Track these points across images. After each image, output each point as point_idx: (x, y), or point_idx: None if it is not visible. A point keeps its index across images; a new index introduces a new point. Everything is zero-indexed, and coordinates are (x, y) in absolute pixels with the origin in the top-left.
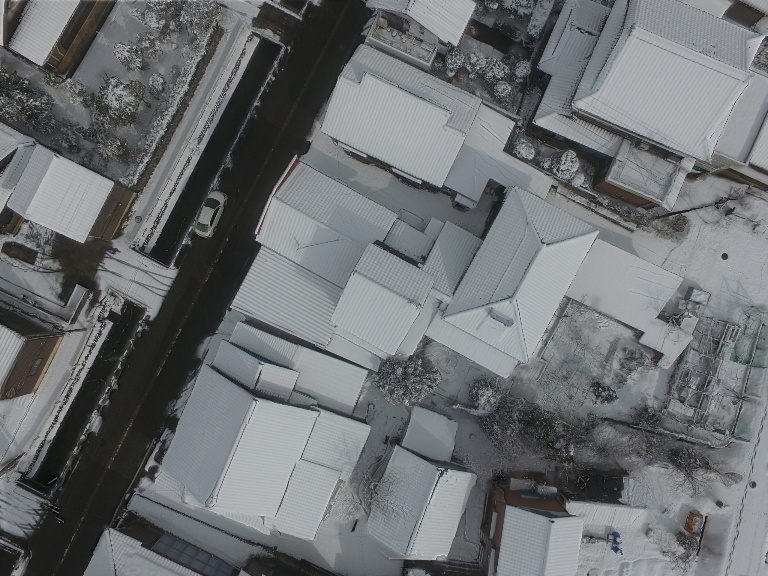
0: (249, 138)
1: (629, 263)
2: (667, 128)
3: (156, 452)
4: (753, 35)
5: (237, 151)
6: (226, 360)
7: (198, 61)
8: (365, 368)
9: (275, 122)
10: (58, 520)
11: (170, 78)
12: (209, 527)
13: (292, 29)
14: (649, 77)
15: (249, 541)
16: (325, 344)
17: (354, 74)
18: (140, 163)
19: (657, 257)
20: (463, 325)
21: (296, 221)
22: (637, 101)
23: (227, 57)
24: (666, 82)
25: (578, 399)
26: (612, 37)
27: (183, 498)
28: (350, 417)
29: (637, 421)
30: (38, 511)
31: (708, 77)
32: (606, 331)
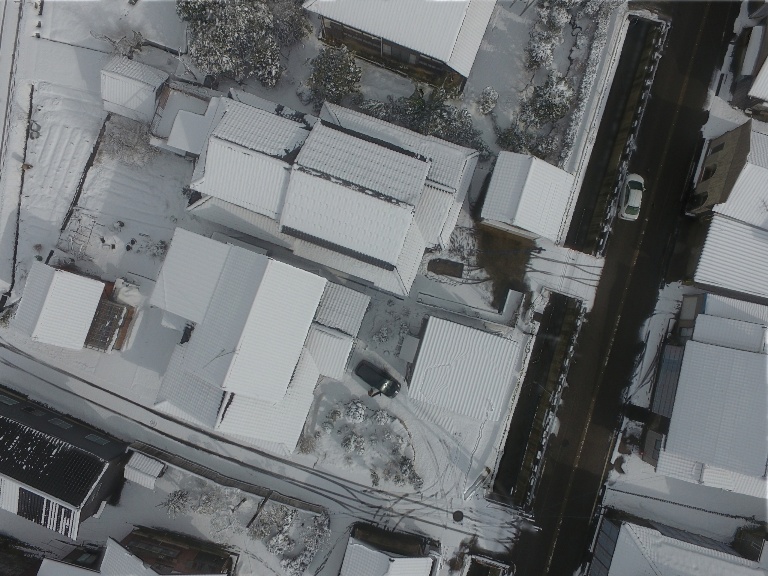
0: (648, 118)
1: None
2: None
3: (620, 442)
4: None
5: (639, 132)
6: (713, 332)
7: None
8: None
9: (670, 98)
10: (535, 528)
11: (563, 72)
12: (687, 508)
13: (668, 6)
14: None
15: (728, 515)
16: None
17: None
18: (566, 157)
19: None
20: None
21: (767, 182)
22: None
23: (610, 43)
24: None
25: None
26: None
27: (701, 477)
28: None
29: None
30: (513, 523)
31: None
32: None
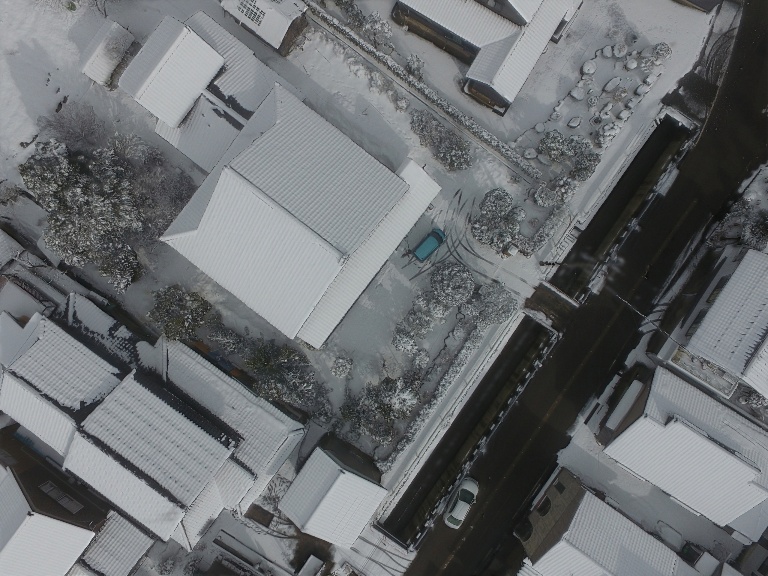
0: (507, 424)
1: None
2: None
3: None
4: None
5: (493, 436)
6: None
7: None
8: None
9: (537, 411)
10: None
11: (434, 354)
12: None
13: (566, 315)
14: None
15: None
16: None
17: (658, 412)
18: (401, 451)
19: None
20: None
21: (580, 562)
22: None
23: (494, 336)
24: None
25: None
26: None
27: None
28: None
29: None
30: None
31: None
32: None
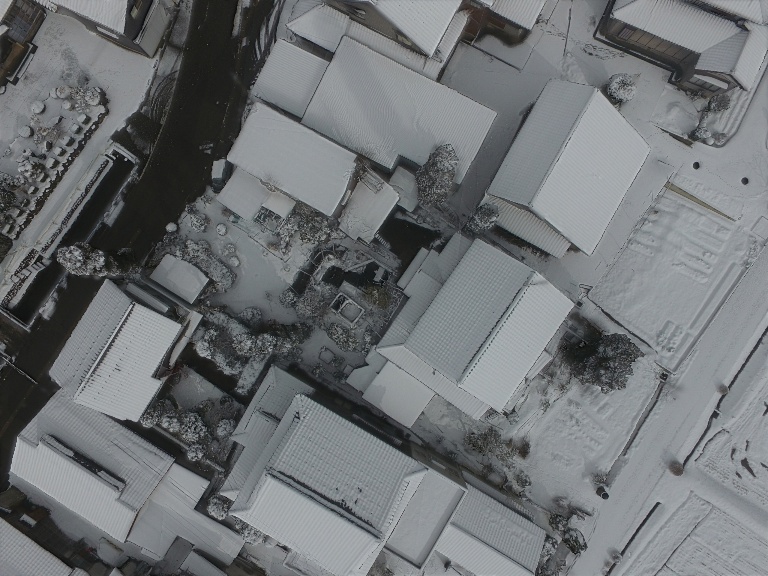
0: None
1: None
2: (317, 553)
3: None
4: (416, 468)
5: None
6: None
7: None
8: None
9: None
10: None
11: None
12: None
13: (19, 339)
14: (292, 512)
15: None
16: None
17: (36, 432)
18: None
19: None
20: None
21: None
22: (286, 526)
23: None
24: (308, 520)
25: None
26: None
27: None
28: None
29: None
30: None
31: (344, 528)
32: None
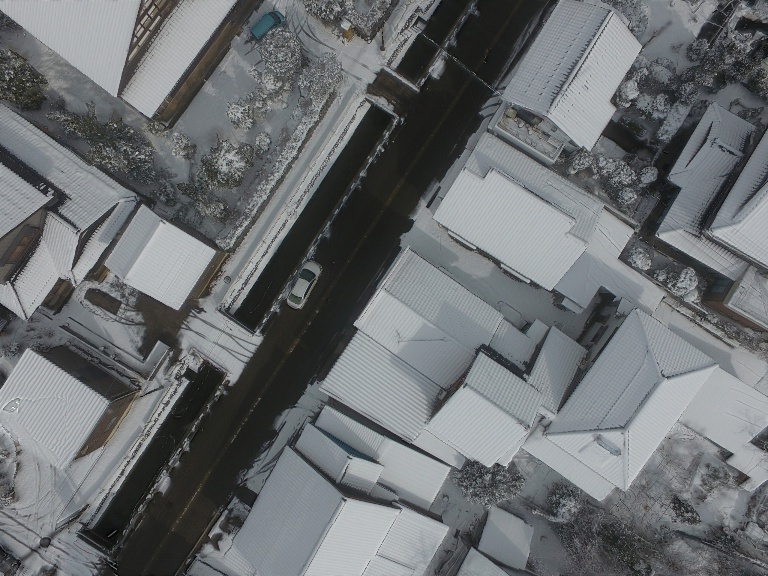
0: (351, 209)
1: (731, 386)
2: None
3: (222, 520)
4: None
5: (337, 221)
6: (311, 446)
7: (310, 127)
8: (448, 465)
9: (379, 195)
10: None
11: (276, 138)
12: None
13: (408, 100)
14: None
15: None
16: (413, 439)
17: (478, 167)
18: (239, 227)
19: (753, 375)
20: (565, 445)
21: (402, 315)
22: None
23: (337, 122)
24: None
25: (655, 512)
26: (762, 166)
27: None
28: (427, 513)
29: (710, 538)
30: (96, 565)
31: None
32: (690, 444)
